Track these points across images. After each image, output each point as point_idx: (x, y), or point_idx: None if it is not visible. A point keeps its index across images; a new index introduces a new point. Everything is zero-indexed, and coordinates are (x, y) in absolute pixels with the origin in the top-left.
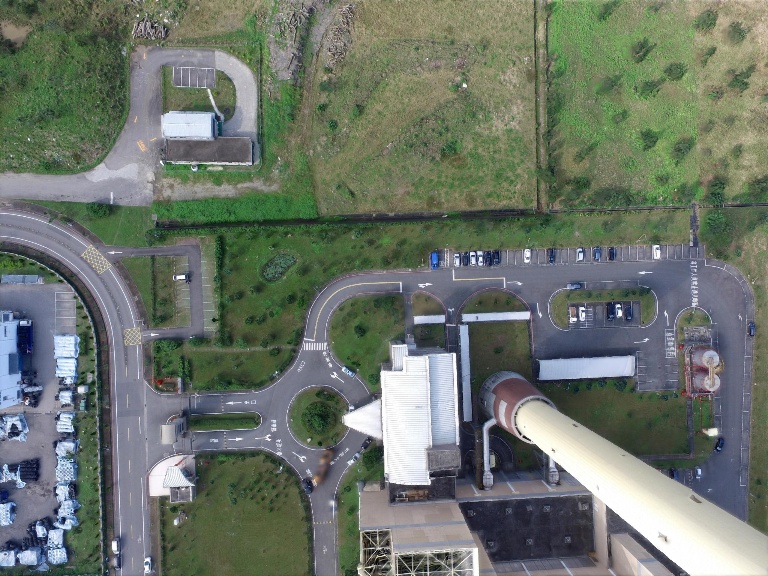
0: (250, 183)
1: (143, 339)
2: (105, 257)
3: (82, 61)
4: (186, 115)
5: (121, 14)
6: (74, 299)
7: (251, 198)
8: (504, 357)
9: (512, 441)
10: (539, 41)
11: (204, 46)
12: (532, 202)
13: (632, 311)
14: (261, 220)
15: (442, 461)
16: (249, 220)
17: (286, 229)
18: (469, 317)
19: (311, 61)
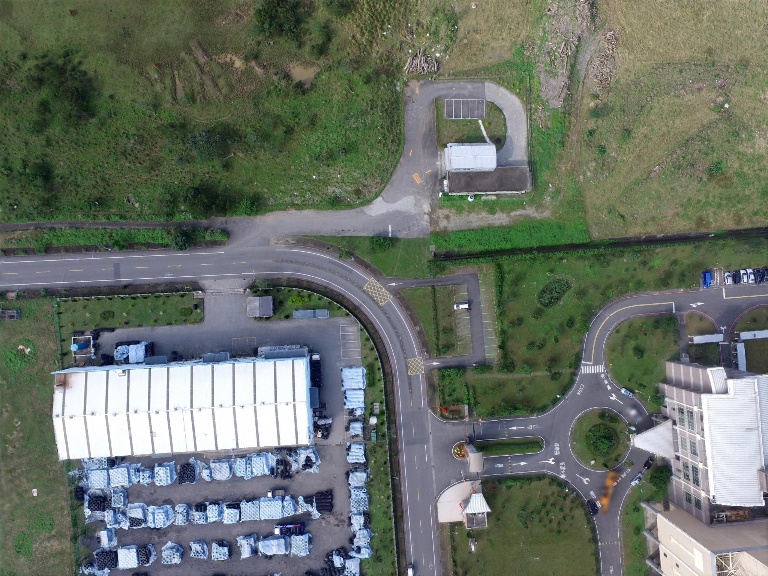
0: (523, 211)
1: (426, 368)
2: (386, 289)
3: (366, 98)
4: (471, 147)
5: (396, 50)
6: (358, 331)
7: (525, 225)
8: None
9: None
10: None
11: (474, 78)
12: None
13: None
14: (535, 247)
15: None
16: (523, 247)
17: (565, 255)
18: (747, 335)
19: (577, 88)
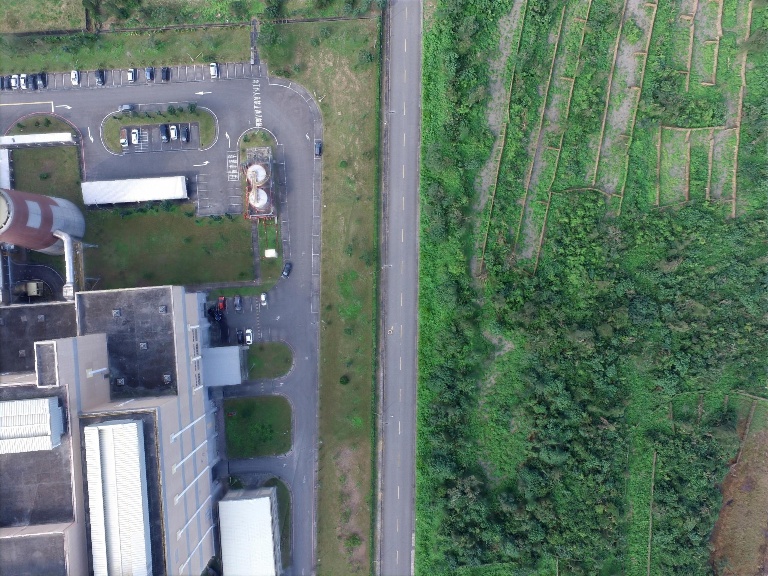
0: None
1: None
2: None
3: None
4: None
5: None
6: None
7: None
8: (53, 184)
9: (63, 270)
10: None
11: None
12: (80, 22)
13: (190, 133)
14: None
15: None
16: None
17: None
18: (5, 139)
19: None
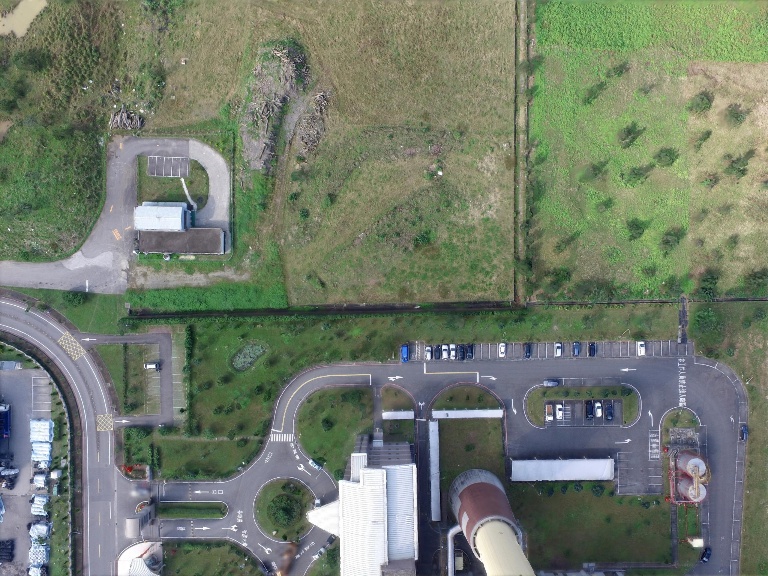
0: (221, 272)
1: (115, 425)
2: (80, 344)
3: (59, 154)
4: (157, 208)
5: (98, 106)
6: (50, 384)
7: (222, 287)
8: (476, 454)
9: None
10: (519, 126)
11: (179, 135)
12: (508, 294)
13: (613, 410)
14: (231, 309)
15: None
16: (220, 309)
17: (255, 320)
18: (439, 414)
19: (284, 149)
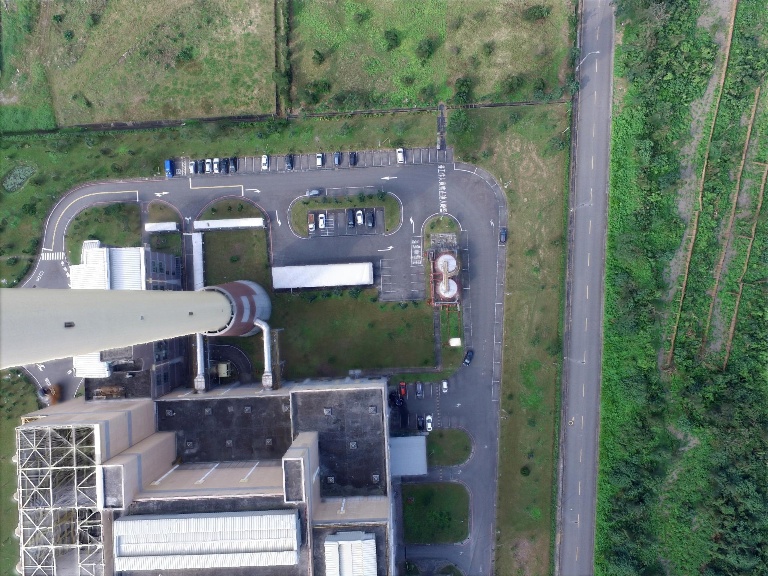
0: None
1: None
2: None
3: None
4: None
5: None
6: None
7: None
8: (241, 266)
9: (249, 352)
10: None
11: None
12: (271, 107)
13: (375, 218)
14: (1, 132)
15: (116, 352)
16: None
17: (20, 138)
18: (200, 224)
19: None
